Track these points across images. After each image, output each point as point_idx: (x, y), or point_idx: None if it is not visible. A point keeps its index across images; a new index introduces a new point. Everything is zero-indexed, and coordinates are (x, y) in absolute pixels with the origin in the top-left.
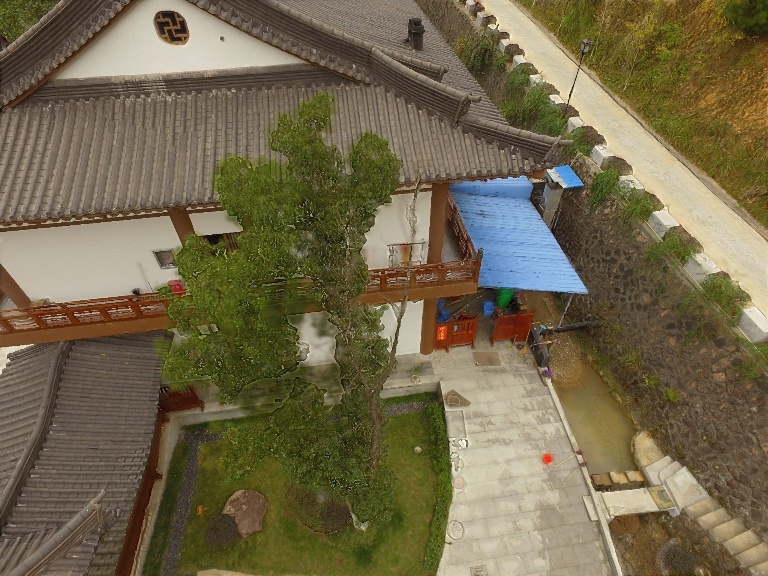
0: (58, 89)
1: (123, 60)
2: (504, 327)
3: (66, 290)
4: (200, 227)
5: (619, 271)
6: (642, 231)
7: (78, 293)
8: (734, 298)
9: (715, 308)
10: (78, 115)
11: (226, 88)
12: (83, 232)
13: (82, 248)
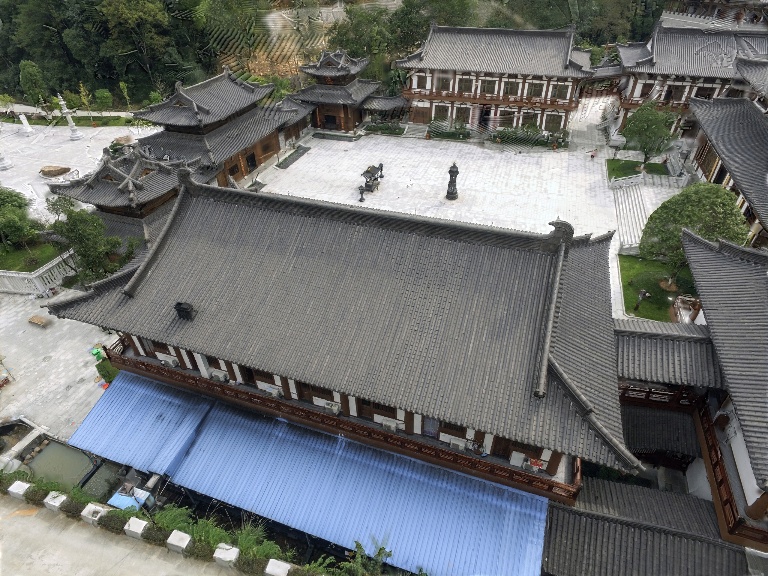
0: None
1: None
2: None
3: None
4: None
5: None
6: None
7: None
8: None
9: None
10: None
11: None
12: None
13: None
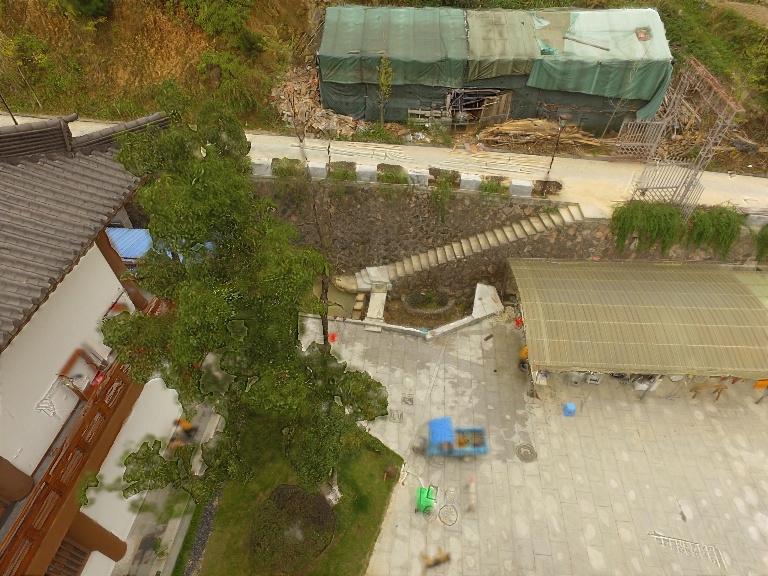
0: None
1: None
2: None
3: None
4: None
5: None
6: None
7: None
8: (294, 166)
9: (293, 179)
10: None
11: None
12: None
13: None
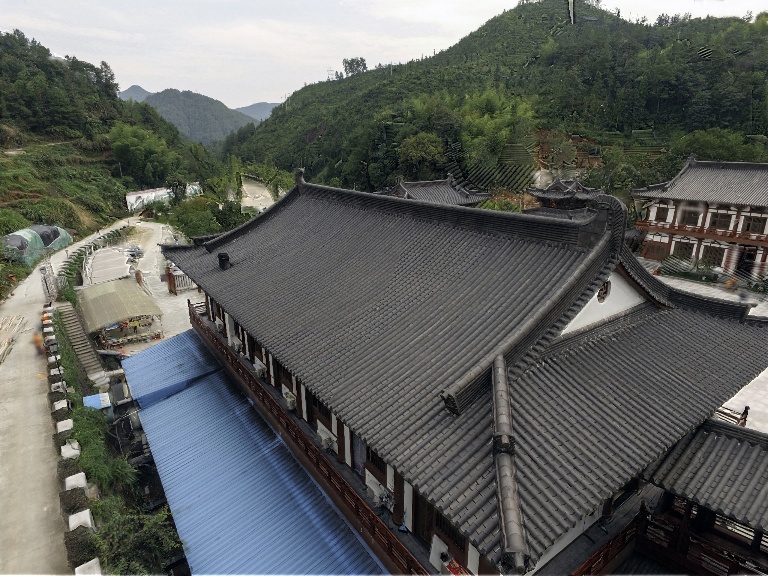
0: None
1: None
2: None
3: None
4: None
5: None
6: None
7: None
8: None
9: None
10: None
11: None
12: None
13: None
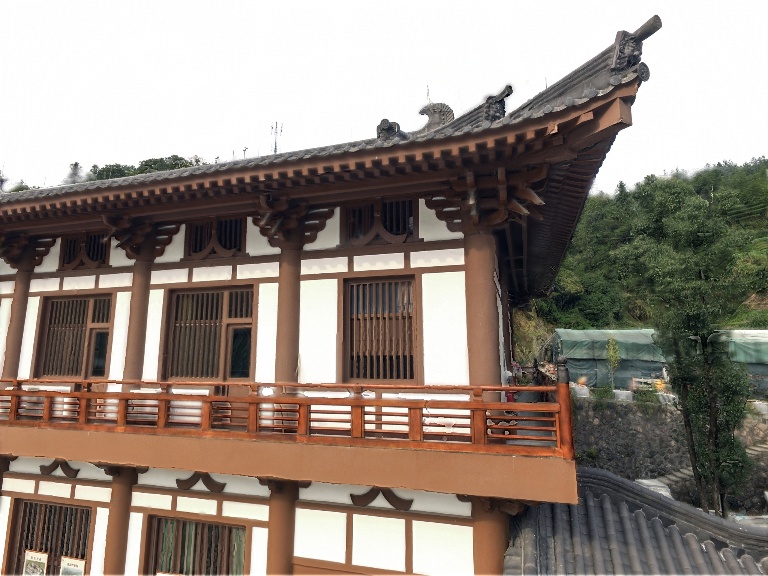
0: None
1: None
2: None
3: None
4: None
5: None
6: None
7: None
8: None
9: None
10: None
11: None
12: None
13: None
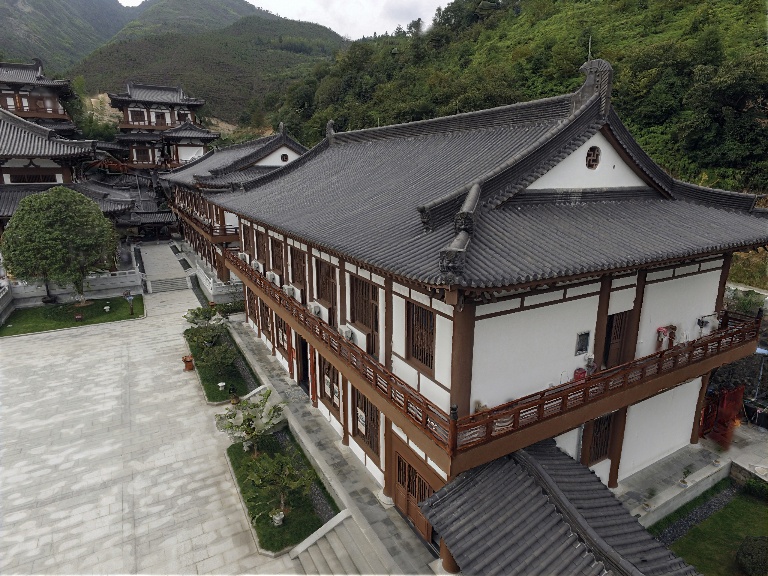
0: (525, 196)
1: (564, 177)
2: (730, 405)
3: (502, 391)
4: (613, 306)
5: (762, 347)
6: (766, 312)
7: (509, 395)
8: None
9: None
10: (545, 213)
11: (608, 200)
12: (545, 314)
13: (536, 334)
